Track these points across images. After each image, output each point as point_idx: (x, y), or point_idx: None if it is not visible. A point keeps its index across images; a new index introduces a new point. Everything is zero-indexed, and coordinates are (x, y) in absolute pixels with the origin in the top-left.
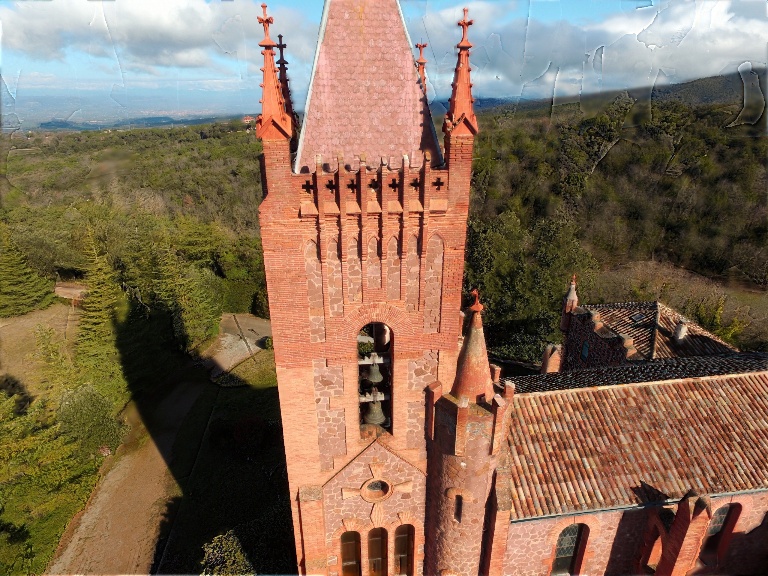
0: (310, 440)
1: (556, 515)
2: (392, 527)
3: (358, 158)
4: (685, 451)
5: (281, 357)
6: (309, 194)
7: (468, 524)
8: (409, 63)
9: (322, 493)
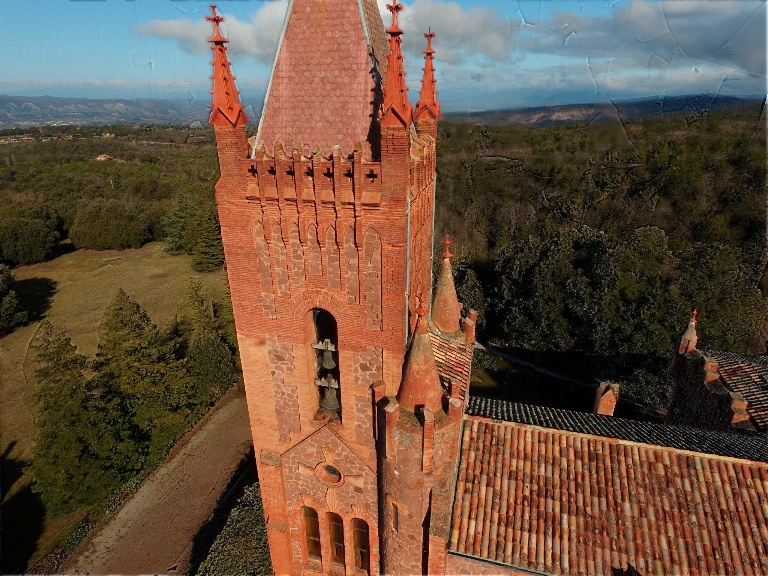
0: (269, 408)
1: (504, 564)
2: (346, 517)
3: (308, 147)
4: (713, 550)
5: (240, 325)
6: (255, 178)
7: (405, 538)
8: (363, 53)
9: (281, 461)
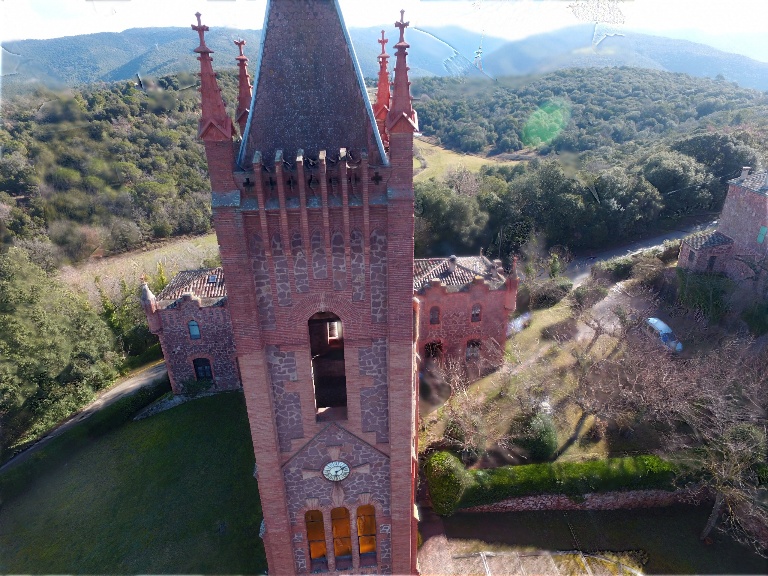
0: None
1: None
2: None
3: None
4: None
5: None
6: None
7: None
8: None
9: None
